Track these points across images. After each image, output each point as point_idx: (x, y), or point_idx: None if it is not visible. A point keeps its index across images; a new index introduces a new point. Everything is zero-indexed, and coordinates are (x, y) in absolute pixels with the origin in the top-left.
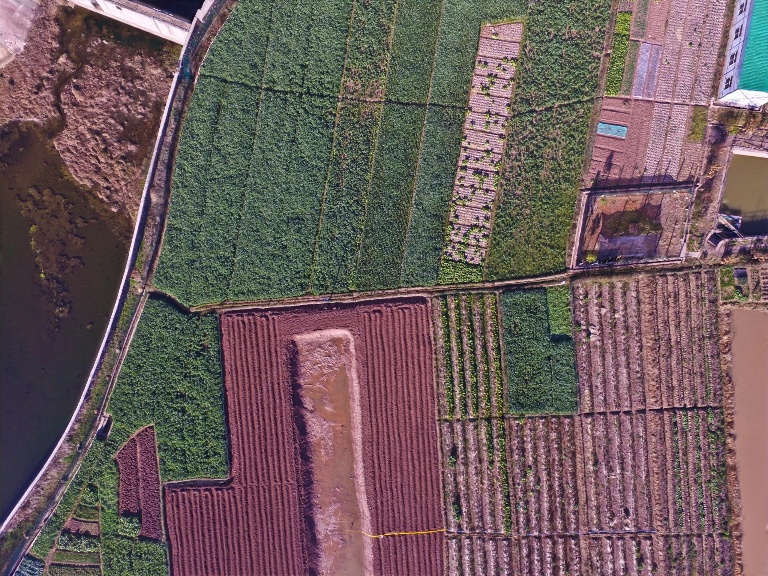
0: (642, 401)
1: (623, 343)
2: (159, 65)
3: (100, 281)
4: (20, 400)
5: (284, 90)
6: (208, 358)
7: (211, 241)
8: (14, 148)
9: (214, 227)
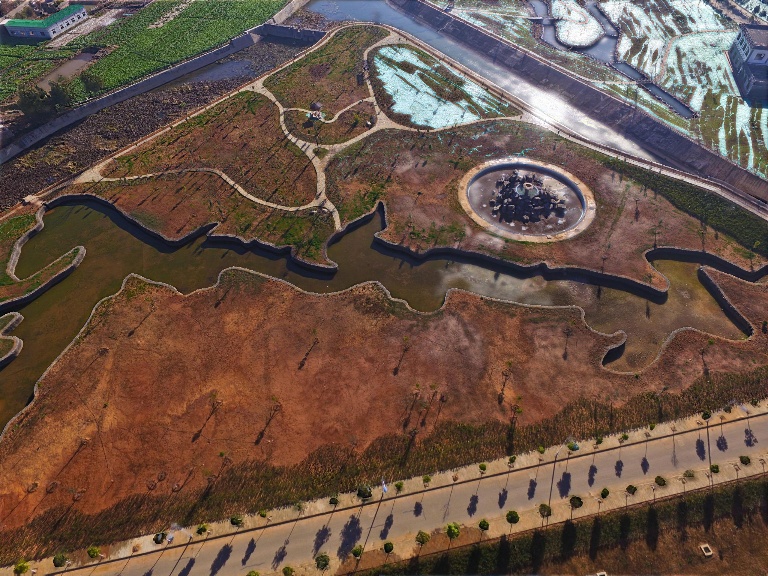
0: None
1: None
2: None
3: (316, 3)
4: None
5: None
6: None
7: None
8: None
9: None
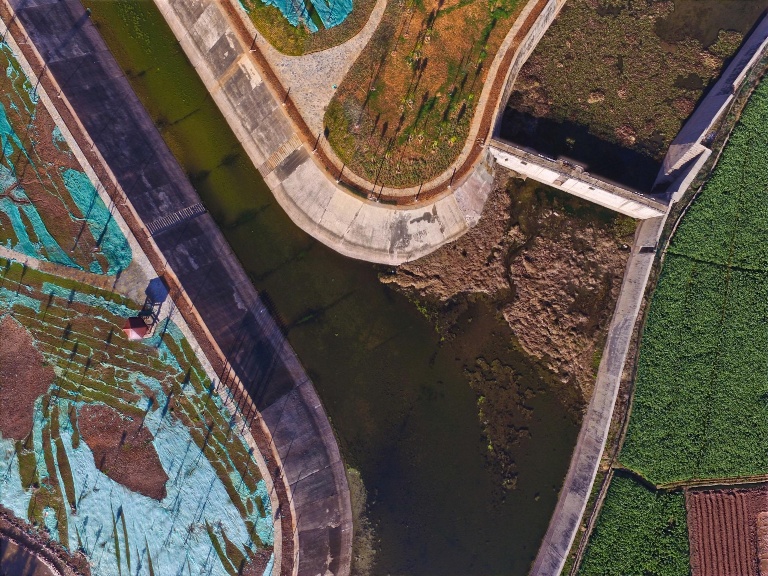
0: None
1: None
2: (612, 238)
3: (547, 452)
4: (464, 573)
5: (752, 269)
6: (676, 536)
7: (681, 419)
8: (461, 319)
9: (684, 405)
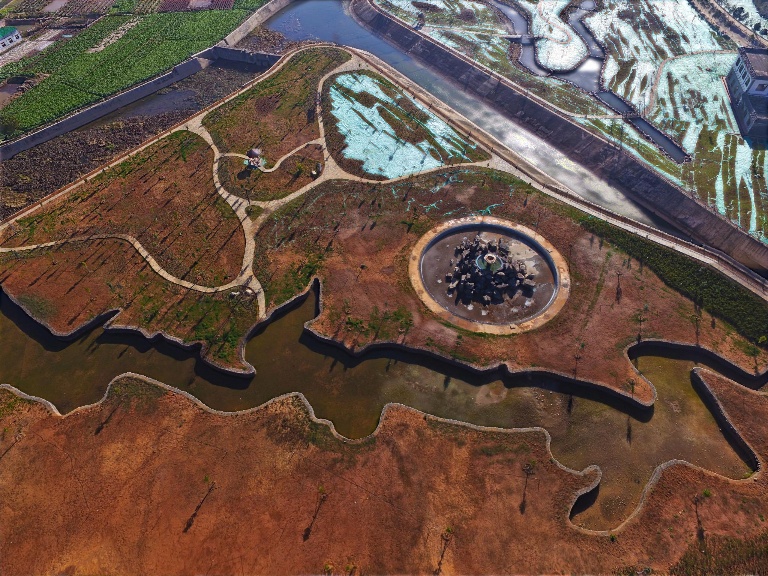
0: (97, 0)
1: (96, 7)
2: None
3: None
4: None
5: None
6: None
7: None
8: None
9: None
